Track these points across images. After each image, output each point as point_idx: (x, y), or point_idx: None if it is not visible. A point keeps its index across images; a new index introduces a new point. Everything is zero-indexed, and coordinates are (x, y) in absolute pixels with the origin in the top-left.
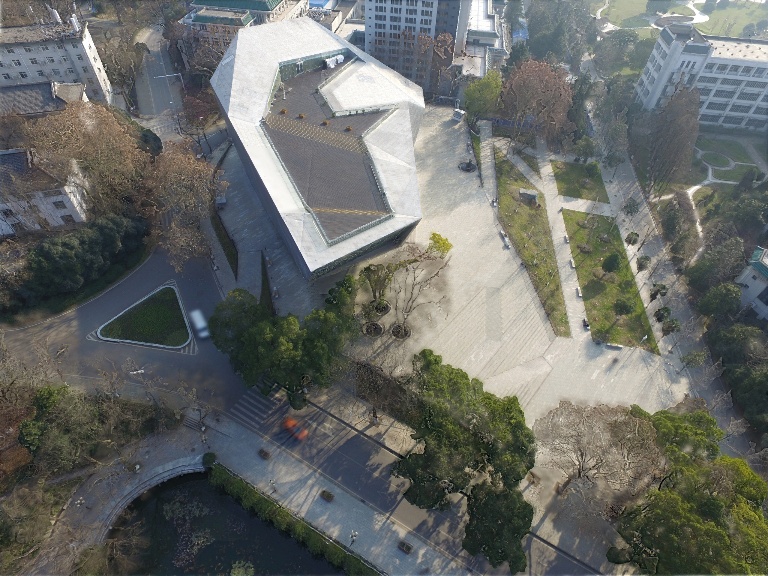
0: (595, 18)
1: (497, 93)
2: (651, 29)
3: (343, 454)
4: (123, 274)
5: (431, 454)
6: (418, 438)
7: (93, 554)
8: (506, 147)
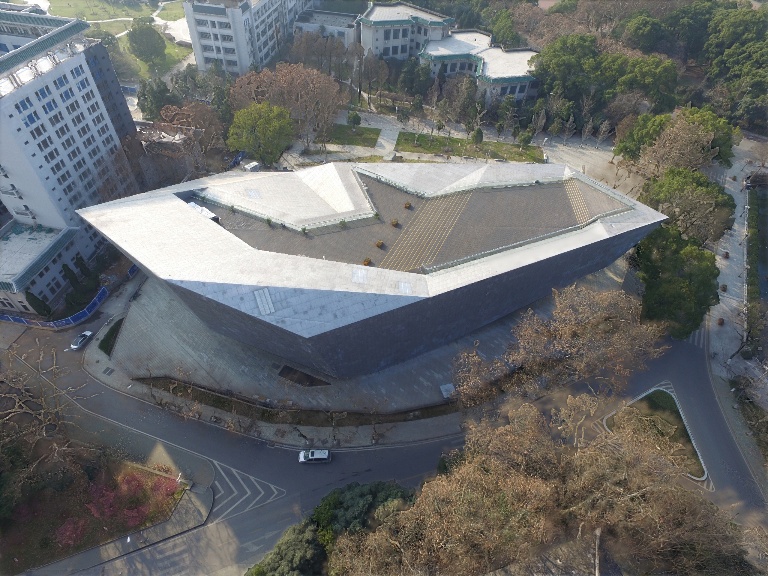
0: None
1: None
2: None
3: None
4: None
5: None
6: None
7: None
8: (301, 158)
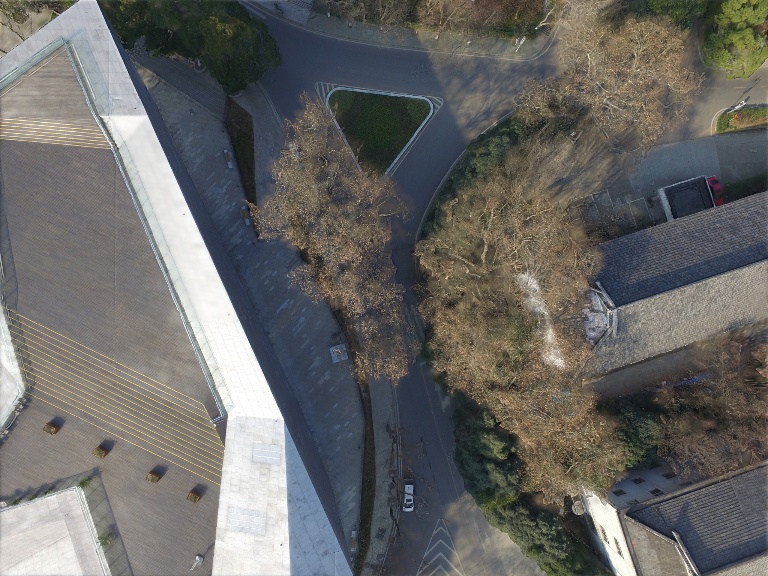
0: None
1: None
2: None
3: None
4: None
5: None
6: None
7: None
8: None
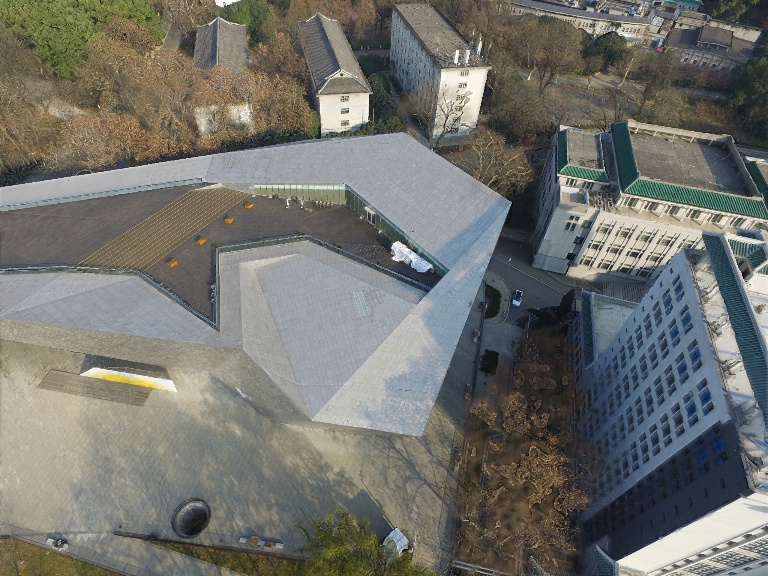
0: None
1: None
2: None
3: None
4: None
5: None
6: None
7: None
8: None
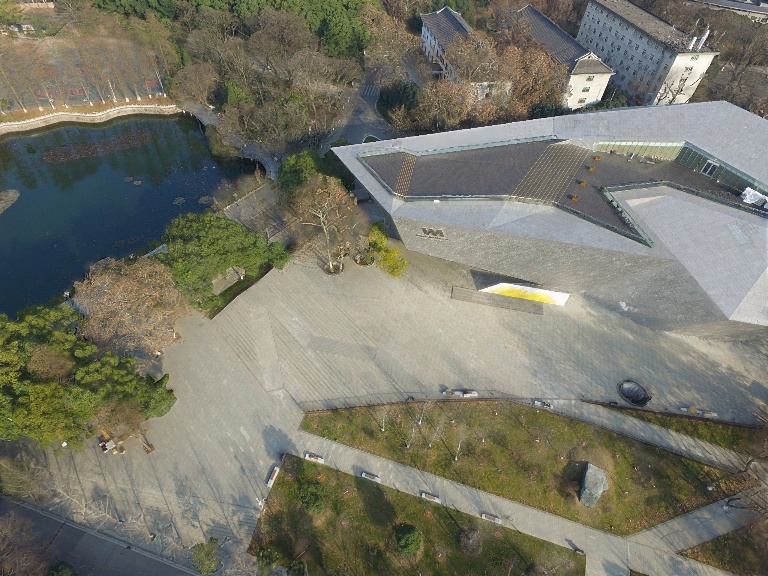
0: None
1: None
2: None
3: None
4: None
5: None
6: None
7: (234, 148)
8: (760, 505)
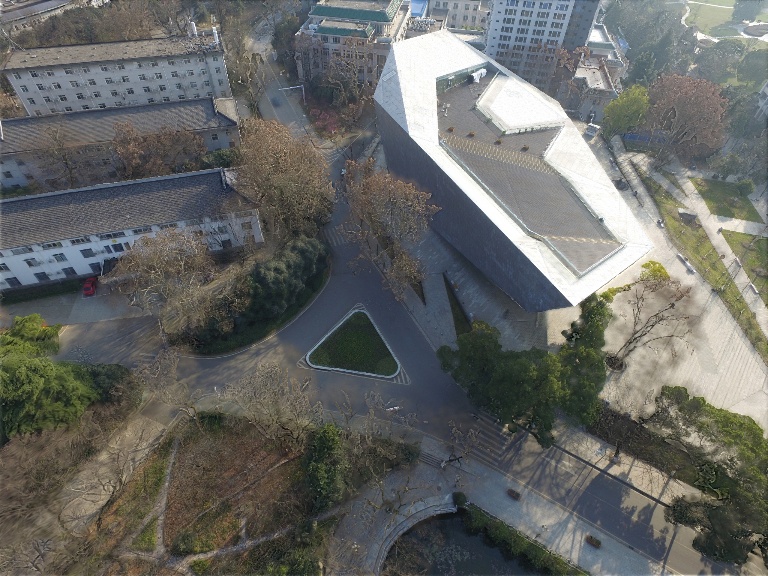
0: (692, 27)
1: (647, 109)
2: (748, 38)
3: (593, 495)
4: (310, 297)
5: (748, 507)
6: (718, 487)
7: None
8: (644, 163)
